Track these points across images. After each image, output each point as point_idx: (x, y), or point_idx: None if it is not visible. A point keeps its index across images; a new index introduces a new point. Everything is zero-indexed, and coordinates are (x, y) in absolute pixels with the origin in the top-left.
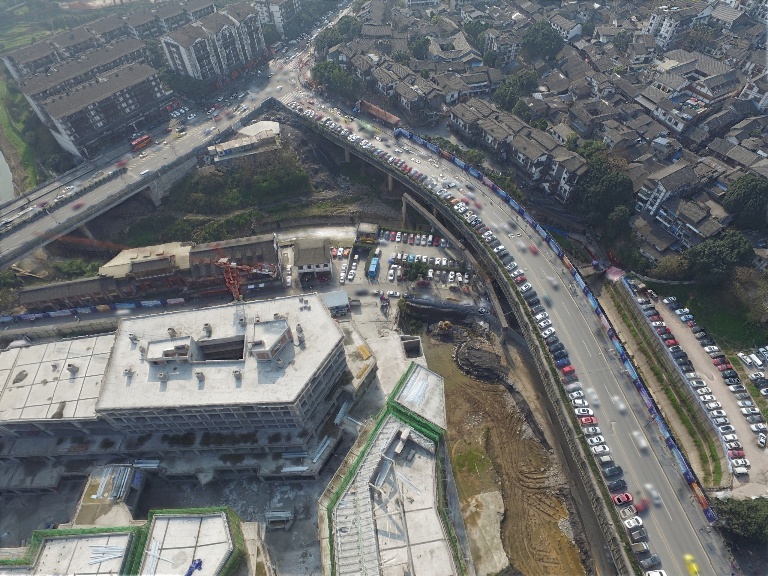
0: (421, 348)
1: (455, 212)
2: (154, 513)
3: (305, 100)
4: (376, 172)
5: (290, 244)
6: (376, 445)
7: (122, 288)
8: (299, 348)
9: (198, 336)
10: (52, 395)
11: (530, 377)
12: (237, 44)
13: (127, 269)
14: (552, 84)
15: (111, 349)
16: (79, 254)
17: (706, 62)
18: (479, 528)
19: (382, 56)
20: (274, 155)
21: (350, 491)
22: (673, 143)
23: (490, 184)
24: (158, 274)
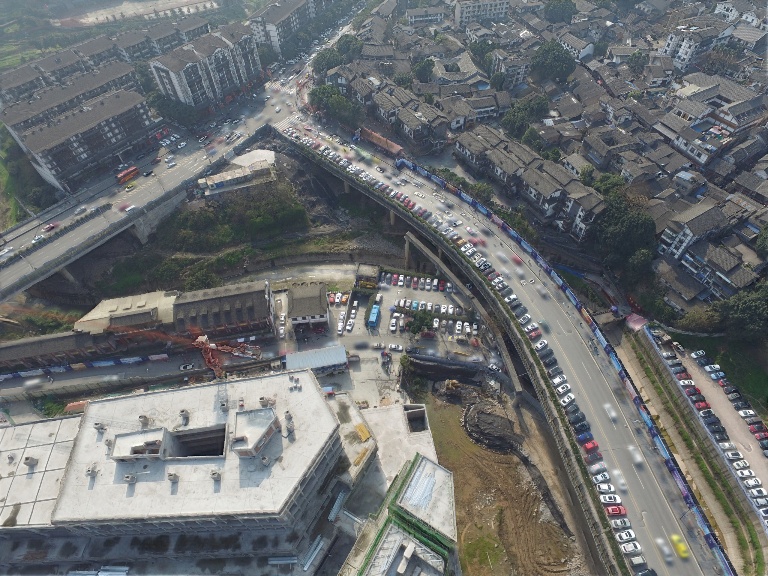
0: (426, 419)
1: (462, 254)
2: None
3: (302, 126)
4: (377, 204)
5: (284, 289)
6: (375, 565)
7: (100, 344)
8: (288, 440)
9: (173, 424)
10: (6, 495)
11: (547, 447)
12: (231, 67)
13: (105, 324)
14: (564, 109)
15: (74, 440)
16: (59, 297)
17: (729, 87)
18: None
19: (383, 80)
20: (268, 188)
21: None
22: (697, 177)
23: (500, 222)
24: (139, 329)
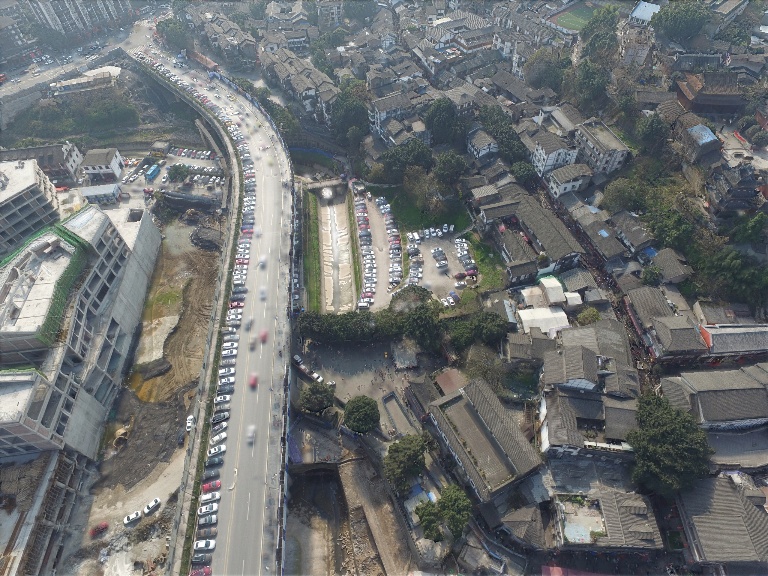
0: (142, 216)
1: (226, 131)
2: None
3: (150, 51)
4: None
5: None
6: (29, 246)
7: None
8: (0, 189)
9: None
10: None
11: None
12: (99, 4)
13: None
14: (358, 40)
15: None
16: None
17: (472, 19)
18: (152, 336)
19: (216, 14)
20: (105, 91)
21: None
22: (418, 81)
23: (264, 112)
24: None
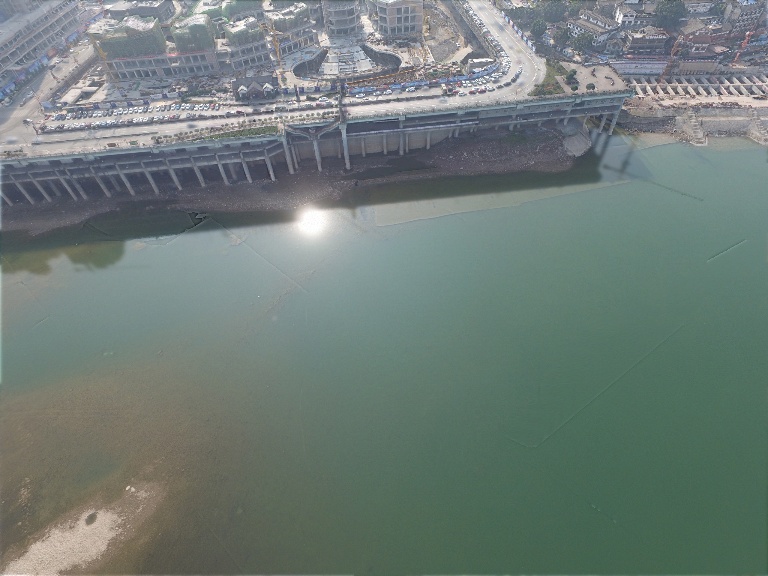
0: None
1: None
2: None
3: None
4: None
5: None
6: None
7: None
8: None
9: None
10: None
11: (444, 5)
12: None
13: None
14: None
15: None
16: None
17: None
18: None
19: None
20: None
21: None
22: None
23: None
24: None
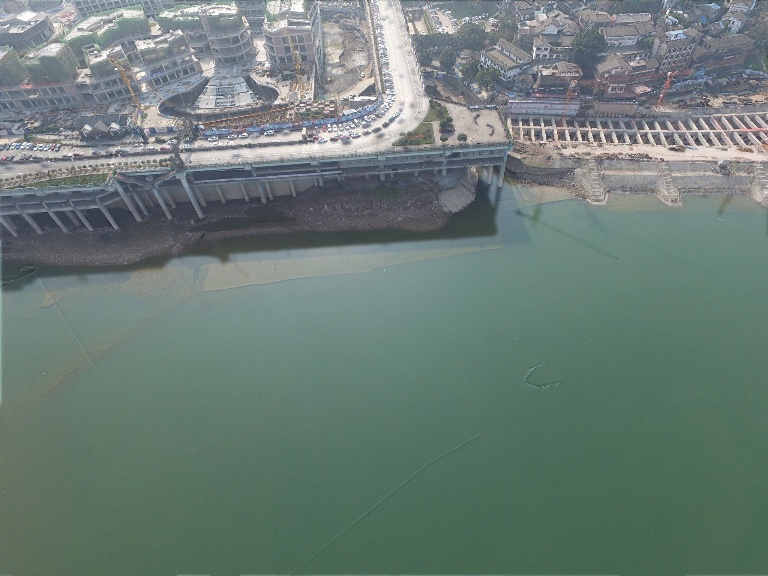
0: (318, 6)
1: None
2: (212, 3)
3: None
4: None
5: None
6: None
7: None
8: None
9: None
10: None
11: None
12: None
13: None
14: None
15: None
16: None
17: None
18: (331, 56)
19: None
20: None
21: (275, 0)
22: None
23: None
24: None
